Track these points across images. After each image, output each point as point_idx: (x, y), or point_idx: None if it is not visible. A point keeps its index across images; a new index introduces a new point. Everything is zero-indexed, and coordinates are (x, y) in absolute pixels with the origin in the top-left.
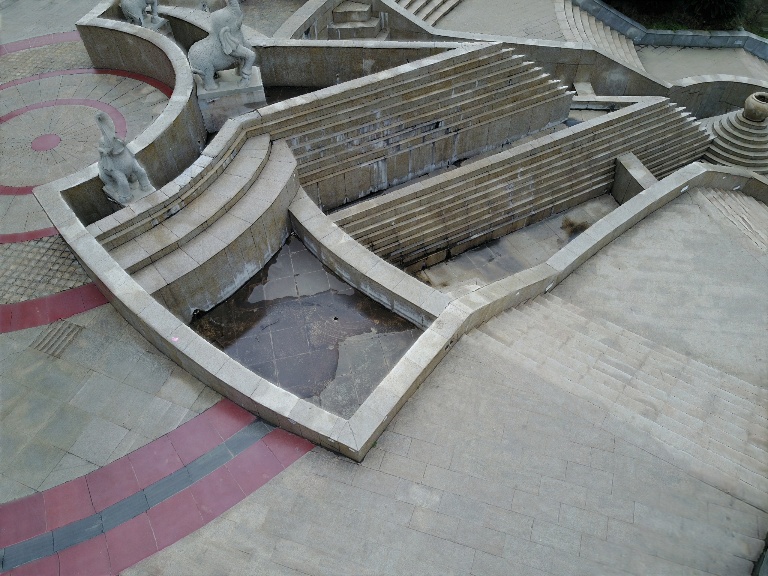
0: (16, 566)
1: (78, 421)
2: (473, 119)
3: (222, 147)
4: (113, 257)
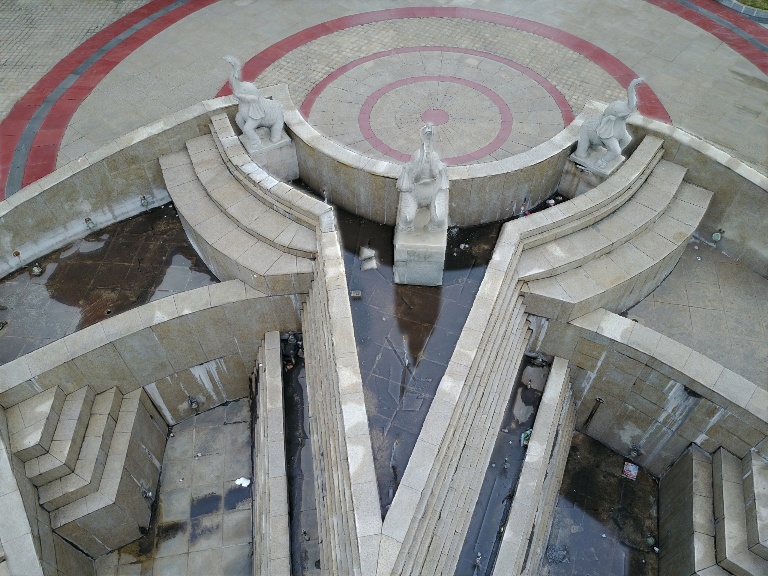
0: (31, 121)
1: (102, 140)
2: (326, 574)
3: (282, 197)
4: (202, 137)
